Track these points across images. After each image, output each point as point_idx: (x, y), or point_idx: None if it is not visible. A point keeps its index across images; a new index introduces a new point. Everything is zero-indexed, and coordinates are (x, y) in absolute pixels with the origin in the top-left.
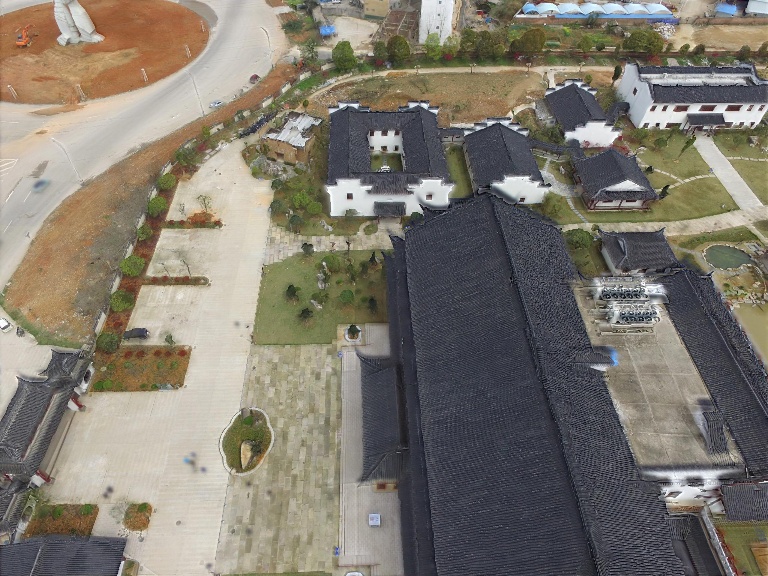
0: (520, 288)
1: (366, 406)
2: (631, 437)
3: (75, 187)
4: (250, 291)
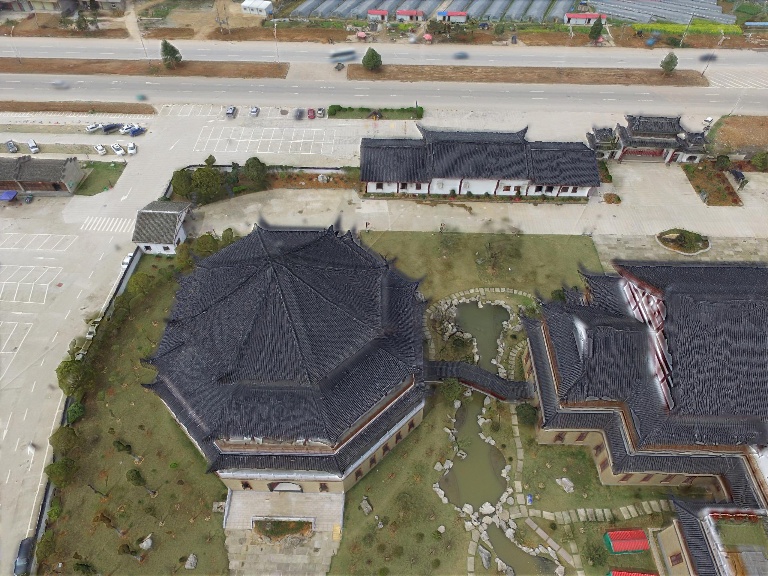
0: None
1: None
2: None
3: None
4: None
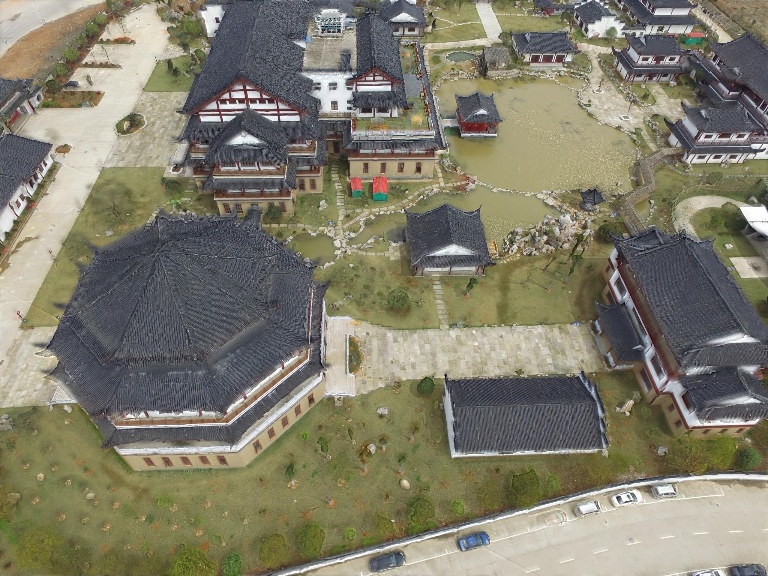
0: (261, 5)
1: (192, 90)
2: (305, 67)
3: (39, 25)
4: (147, 71)
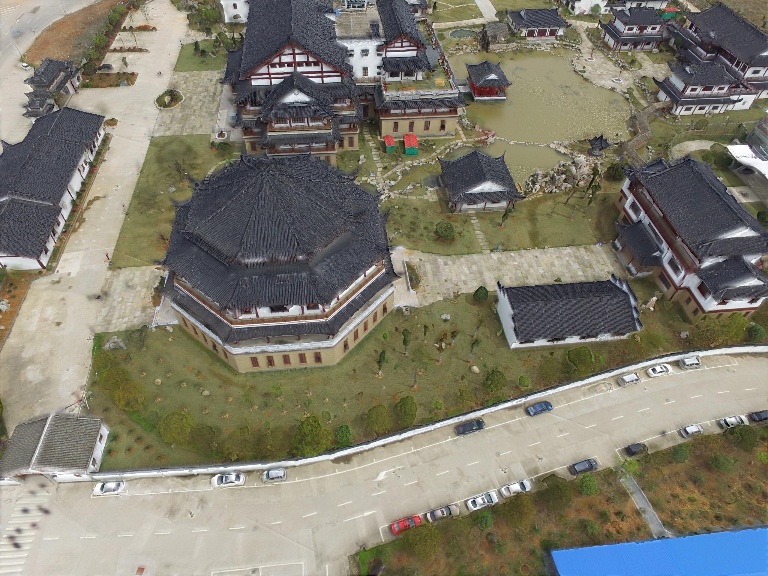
0: None
1: (228, 64)
2: (339, 37)
3: (60, 17)
4: (174, 54)
